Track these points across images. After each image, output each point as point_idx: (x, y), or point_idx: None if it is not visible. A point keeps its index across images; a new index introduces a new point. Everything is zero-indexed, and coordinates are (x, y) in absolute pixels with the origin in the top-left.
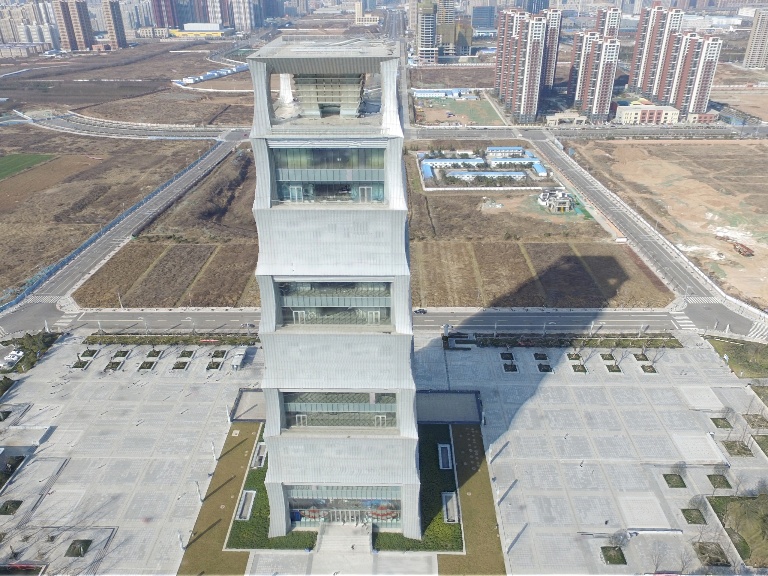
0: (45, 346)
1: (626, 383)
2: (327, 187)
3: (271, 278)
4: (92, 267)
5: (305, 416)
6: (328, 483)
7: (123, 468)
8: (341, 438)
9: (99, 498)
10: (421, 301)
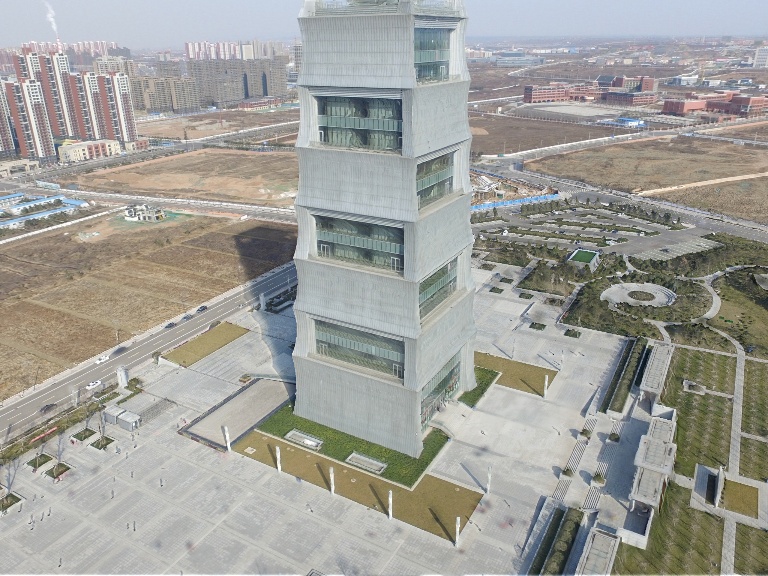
0: None
1: None
2: (428, 68)
3: None
4: None
5: None
6: None
7: (209, 554)
8: None
9: None
10: (185, 305)
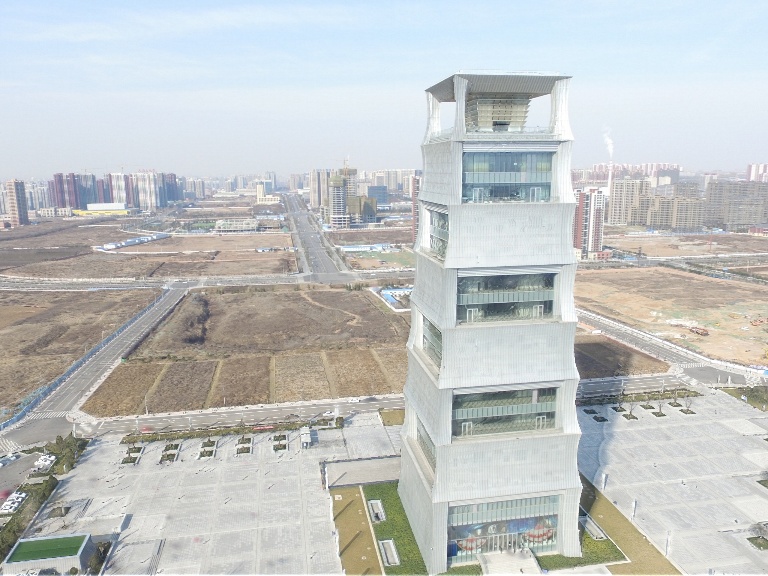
0: (79, 448)
1: (676, 423)
2: (504, 189)
3: (456, 272)
4: (90, 386)
5: (471, 424)
6: (493, 499)
7: (232, 540)
8: (511, 440)
9: (220, 569)
10: None
